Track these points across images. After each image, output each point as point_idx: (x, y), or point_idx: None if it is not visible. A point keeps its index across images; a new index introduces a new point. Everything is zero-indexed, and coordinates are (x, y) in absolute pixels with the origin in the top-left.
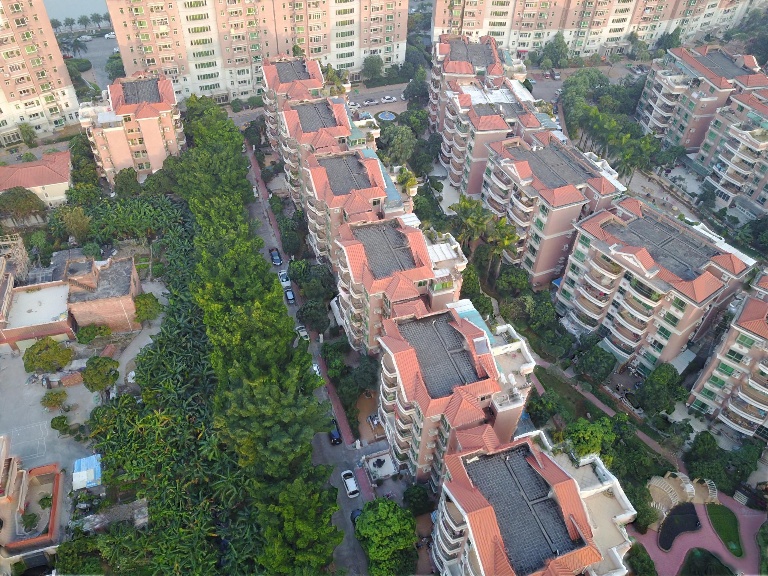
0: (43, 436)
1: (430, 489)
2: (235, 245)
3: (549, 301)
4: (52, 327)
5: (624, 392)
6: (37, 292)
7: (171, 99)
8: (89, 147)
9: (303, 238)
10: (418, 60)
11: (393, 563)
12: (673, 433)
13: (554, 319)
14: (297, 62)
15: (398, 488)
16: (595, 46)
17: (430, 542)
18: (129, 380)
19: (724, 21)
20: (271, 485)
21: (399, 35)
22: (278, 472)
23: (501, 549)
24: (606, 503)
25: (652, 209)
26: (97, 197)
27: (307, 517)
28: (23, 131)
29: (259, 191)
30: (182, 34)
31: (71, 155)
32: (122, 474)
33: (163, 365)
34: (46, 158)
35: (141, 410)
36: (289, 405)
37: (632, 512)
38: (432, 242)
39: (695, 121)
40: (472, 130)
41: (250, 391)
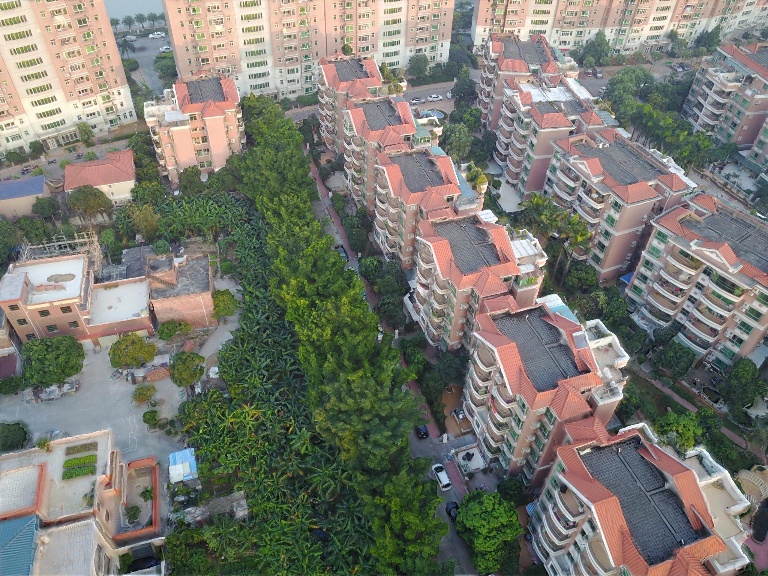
0: (133, 430)
1: (521, 482)
2: (309, 242)
3: (620, 297)
4: (134, 323)
5: (701, 387)
6: (115, 289)
7: (235, 98)
8: (148, 146)
9: (366, 235)
10: (462, 59)
11: (499, 554)
12: (758, 427)
13: (627, 315)
14: (353, 61)
15: (489, 481)
16: (635, 44)
17: (527, 534)
18: (211, 375)
19: (761, 19)
20: (373, 477)
21: (444, 34)
22: (380, 465)
23: (629, 538)
24: (717, 494)
25: (726, 205)
26: (162, 195)
27: (412, 509)
28: (82, 130)
29: (318, 189)
30: (236, 34)
31: (133, 154)
32: (217, 467)
33: (246, 360)
34: (110, 157)
35: (229, 405)
36: (385, 399)
37: (745, 503)
38: None
39: (748, 118)
40: (535, 128)
41: (347, 385)
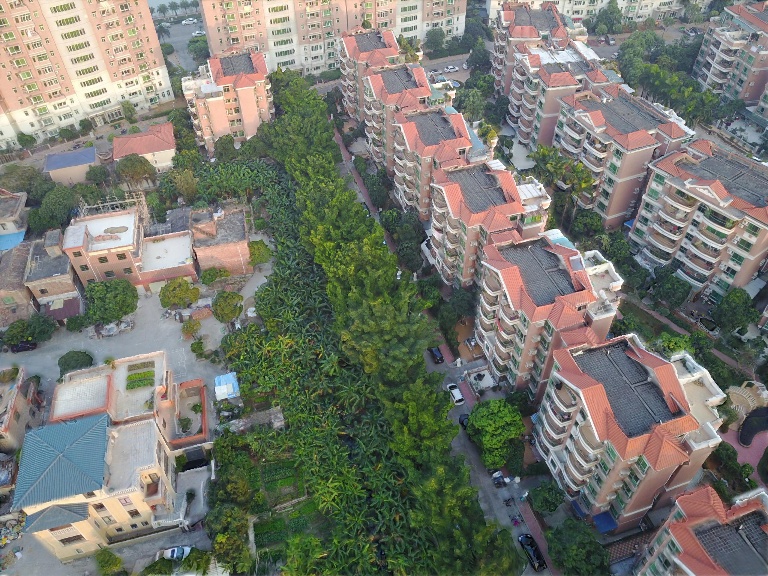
0: (182, 360)
1: (528, 397)
2: (334, 196)
3: (623, 240)
4: (180, 270)
5: (699, 317)
6: (162, 242)
7: (264, 70)
8: (186, 120)
9: (387, 193)
10: (477, 31)
11: (505, 451)
12: (748, 348)
13: (629, 254)
14: (372, 34)
15: (498, 397)
16: (648, 11)
17: (532, 439)
18: (249, 315)
19: None
20: (393, 388)
21: (459, 8)
22: (399, 377)
23: (612, 418)
24: (697, 390)
25: (721, 149)
26: (200, 162)
27: (427, 413)
28: (125, 108)
29: None
30: (263, 13)
31: (173, 126)
32: (257, 387)
33: (280, 299)
34: (152, 129)
35: (265, 337)
36: (403, 322)
37: (722, 395)
38: (516, 185)
39: (754, 74)
40: (543, 87)
41: (369, 310)
